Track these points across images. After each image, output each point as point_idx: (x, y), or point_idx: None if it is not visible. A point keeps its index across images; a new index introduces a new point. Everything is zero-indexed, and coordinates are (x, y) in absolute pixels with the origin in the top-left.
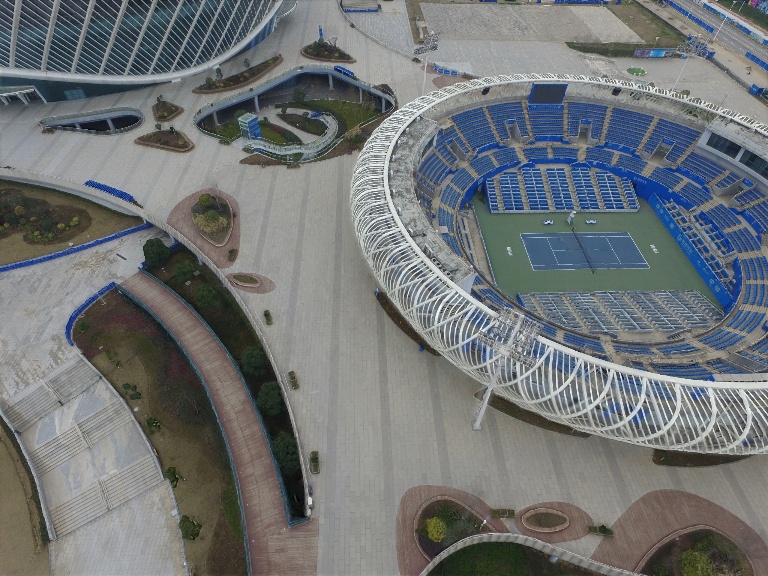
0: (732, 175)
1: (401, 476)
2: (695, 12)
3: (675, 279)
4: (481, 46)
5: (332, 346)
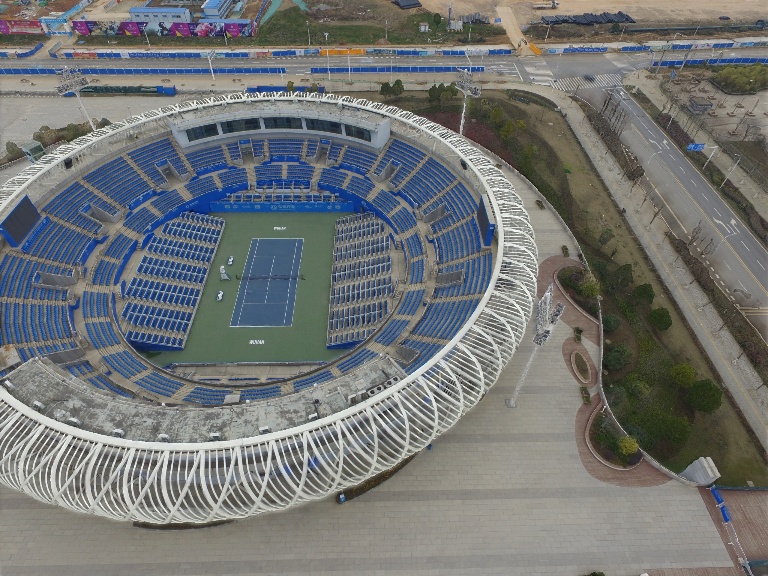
0: (229, 146)
1: (578, 480)
2: None
3: (319, 228)
4: None
5: (430, 567)
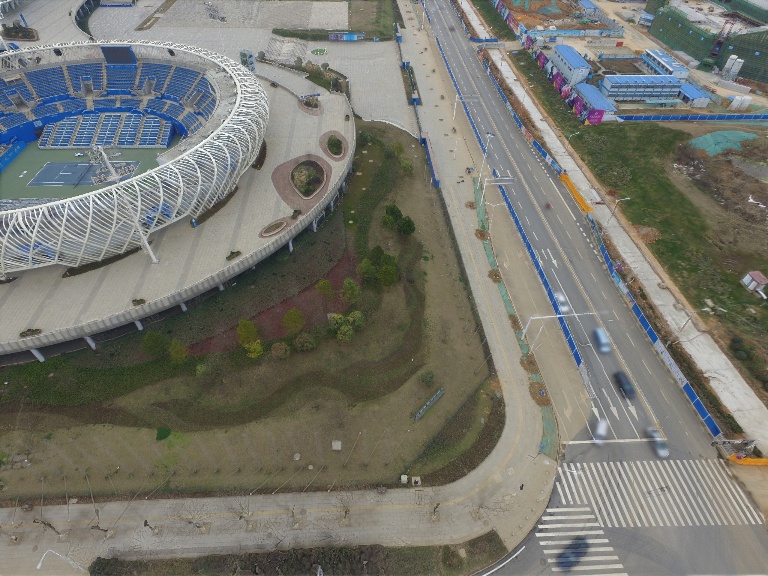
0: None
1: None
2: (438, 7)
3: None
4: (191, 32)
5: None
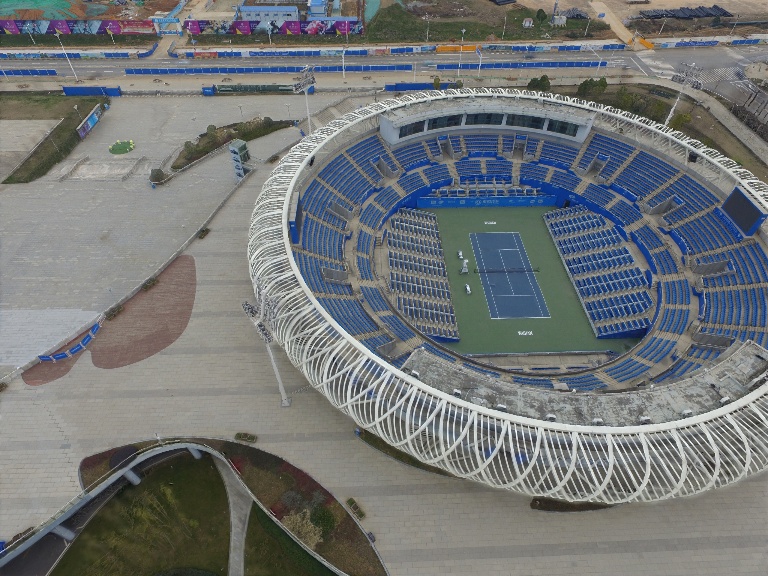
0: (429, 142)
1: None
2: None
3: (528, 222)
4: None
5: None
